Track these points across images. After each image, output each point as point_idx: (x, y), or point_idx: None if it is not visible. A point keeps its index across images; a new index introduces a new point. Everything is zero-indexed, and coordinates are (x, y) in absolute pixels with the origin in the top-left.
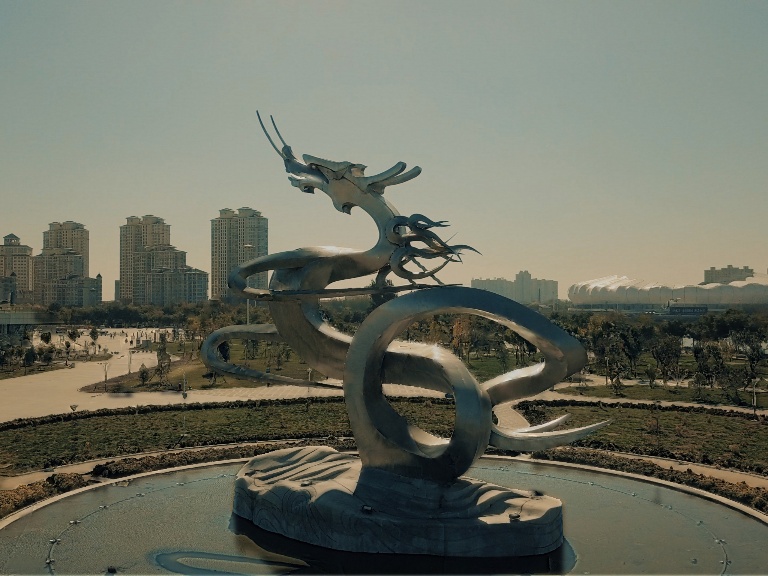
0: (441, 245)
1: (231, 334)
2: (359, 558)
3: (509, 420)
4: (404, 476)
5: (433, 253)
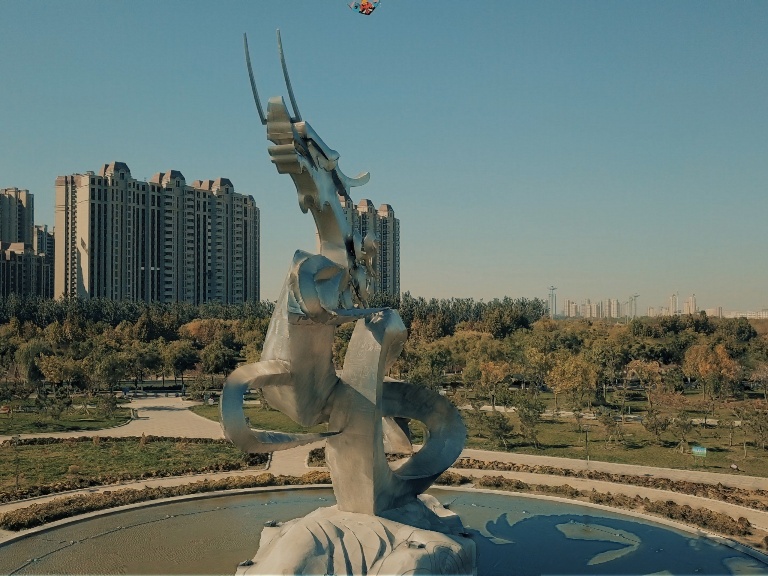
0: None
1: None
2: None
3: None
4: (399, 508)
5: None
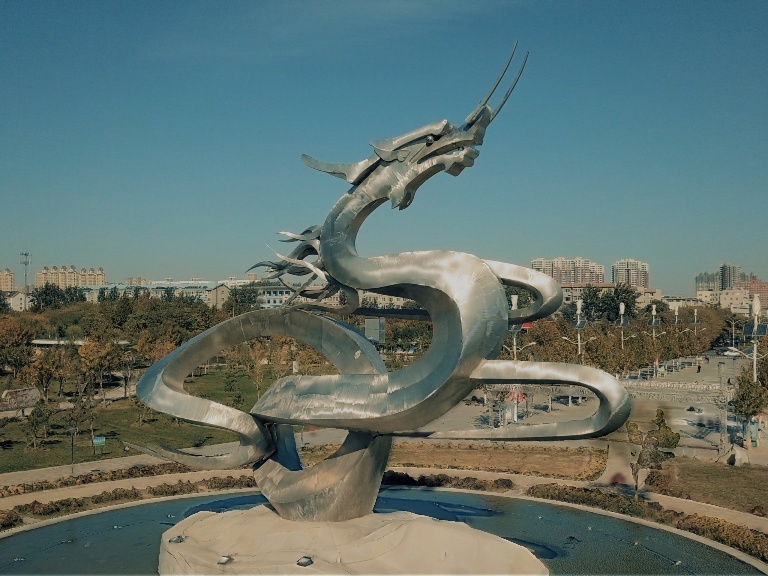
0: None
1: None
2: None
3: None
4: None
5: (294, 269)
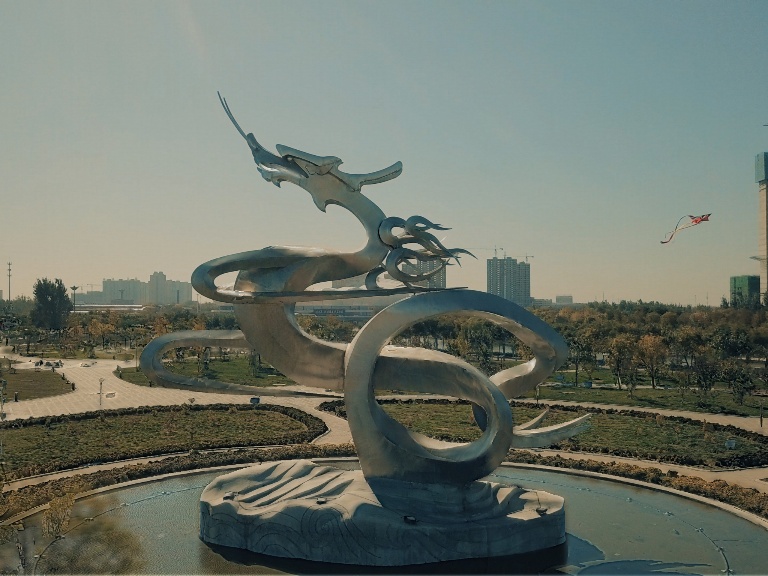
0: (440, 248)
1: (182, 341)
2: (407, 571)
3: (331, 422)
4: (416, 483)
5: (430, 256)
